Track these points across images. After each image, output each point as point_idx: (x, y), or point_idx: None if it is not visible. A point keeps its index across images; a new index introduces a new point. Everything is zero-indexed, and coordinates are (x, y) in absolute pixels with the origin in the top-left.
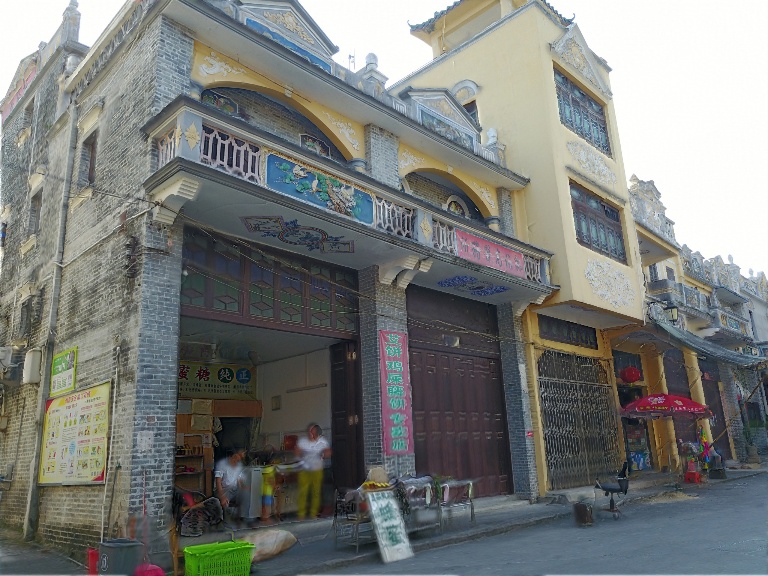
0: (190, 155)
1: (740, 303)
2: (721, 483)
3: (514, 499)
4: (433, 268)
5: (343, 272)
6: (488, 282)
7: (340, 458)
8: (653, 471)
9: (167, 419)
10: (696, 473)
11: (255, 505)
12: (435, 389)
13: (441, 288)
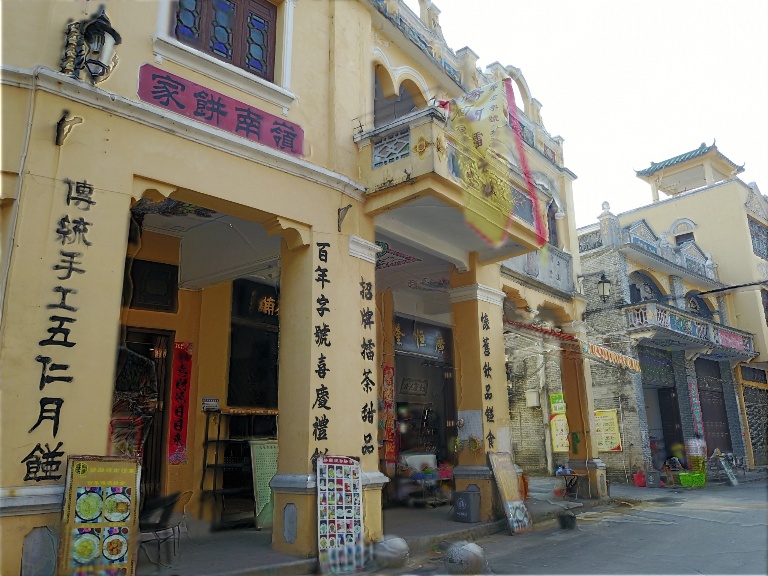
0: (656, 323)
1: None
2: None
3: None
4: None
5: (667, 353)
6: (729, 354)
7: (671, 444)
8: None
9: (646, 427)
10: None
11: None
12: (701, 410)
13: (701, 356)
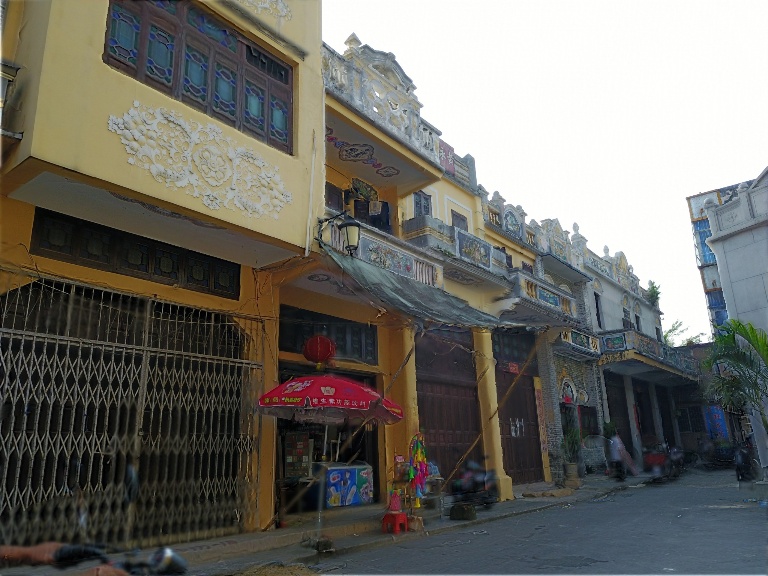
0: None
1: (582, 282)
2: (456, 529)
3: None
4: None
5: None
6: None
7: None
8: (374, 506)
9: None
10: (400, 515)
11: None
12: None
13: None
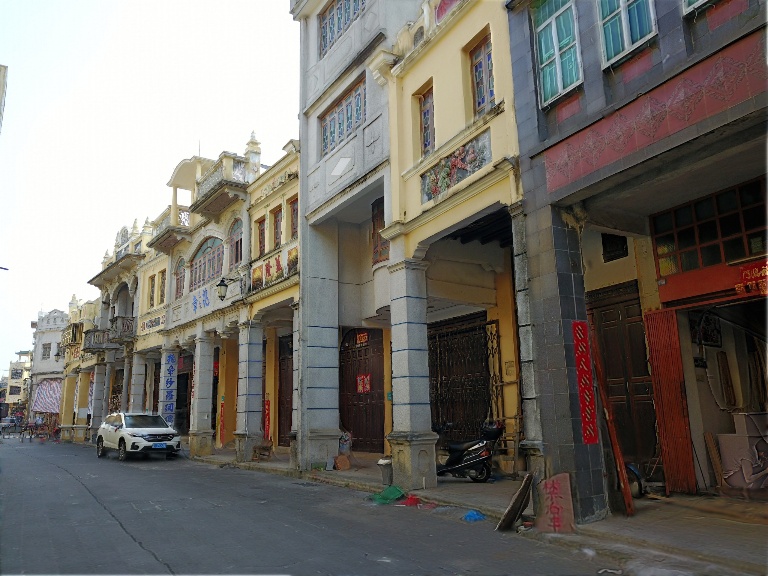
0: None
1: None
2: None
3: None
4: None
5: None
6: None
7: None
8: None
9: None
10: None
11: None
12: None
13: None
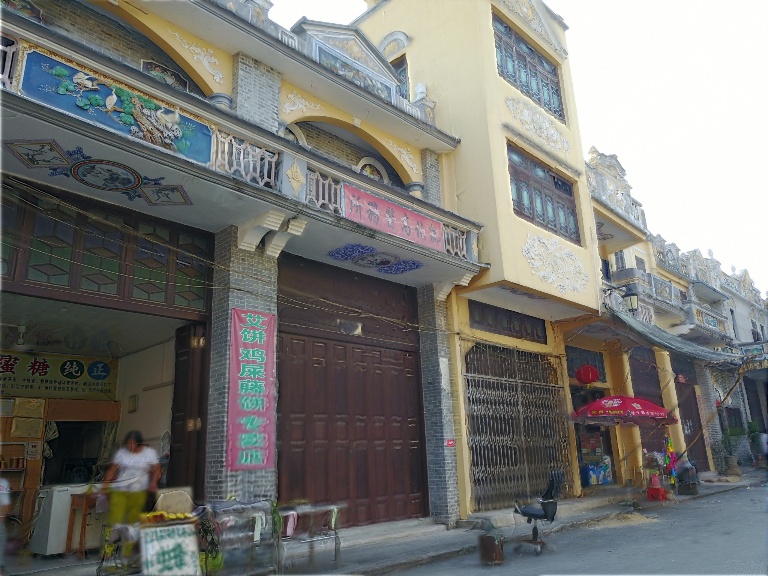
0: None
1: (720, 301)
2: (691, 500)
3: (428, 523)
4: (311, 231)
5: (191, 234)
6: (392, 254)
7: (175, 474)
8: (615, 485)
9: None
10: (661, 489)
11: (55, 537)
12: (323, 386)
13: (336, 262)
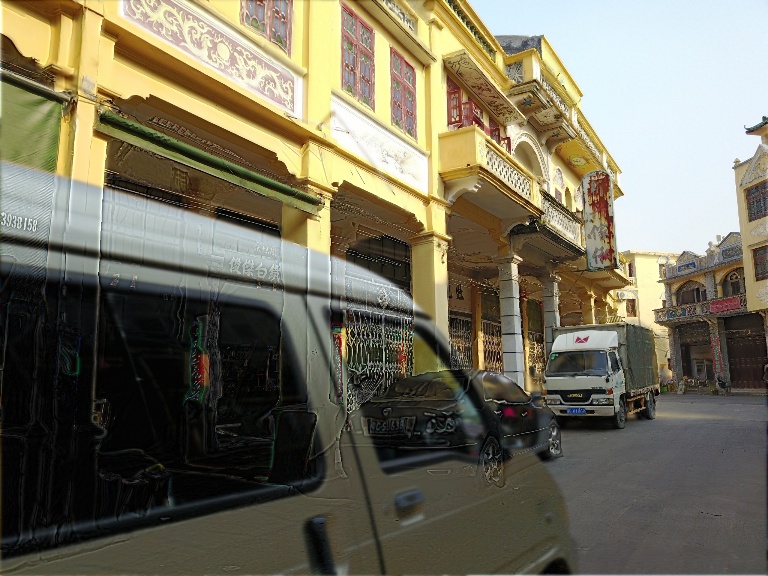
0: None
1: None
2: None
3: None
4: None
5: None
6: None
7: None
8: None
9: None
10: None
11: None
12: None
13: None
